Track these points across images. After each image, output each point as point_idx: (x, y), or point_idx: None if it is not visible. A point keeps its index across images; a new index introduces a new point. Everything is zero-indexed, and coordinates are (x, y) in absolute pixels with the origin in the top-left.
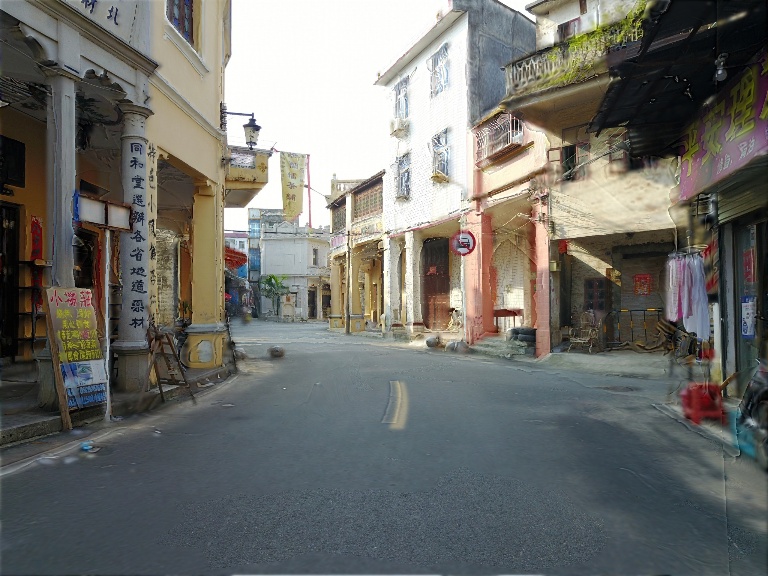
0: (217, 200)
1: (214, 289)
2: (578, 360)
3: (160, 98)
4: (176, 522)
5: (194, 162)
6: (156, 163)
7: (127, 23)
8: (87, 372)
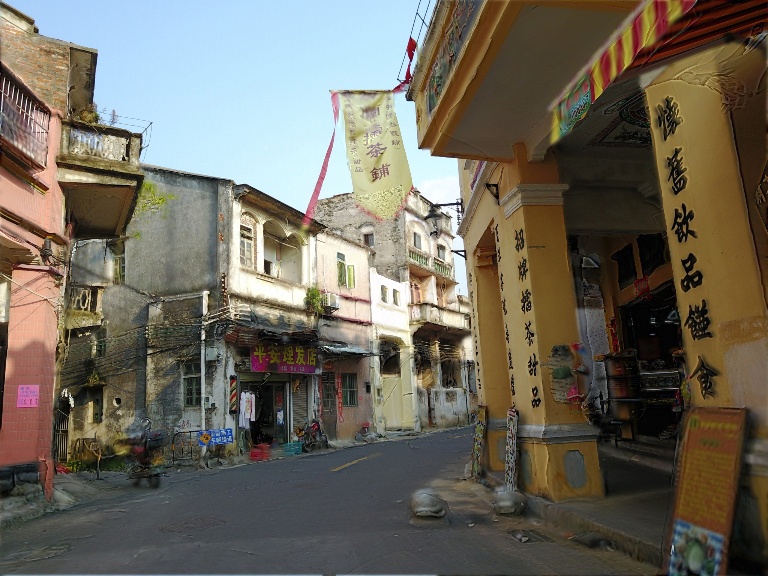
0: None
1: None
2: (78, 489)
3: None
4: None
5: None
6: None
7: None
8: None
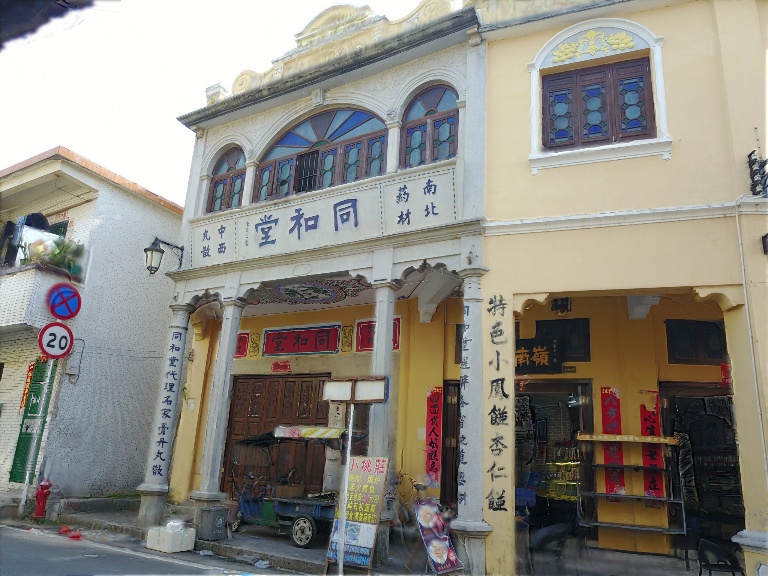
0: (750, 310)
1: (764, 467)
2: None
3: (521, 240)
4: (5, 566)
5: (647, 277)
6: (511, 313)
7: (449, 205)
8: (356, 533)
